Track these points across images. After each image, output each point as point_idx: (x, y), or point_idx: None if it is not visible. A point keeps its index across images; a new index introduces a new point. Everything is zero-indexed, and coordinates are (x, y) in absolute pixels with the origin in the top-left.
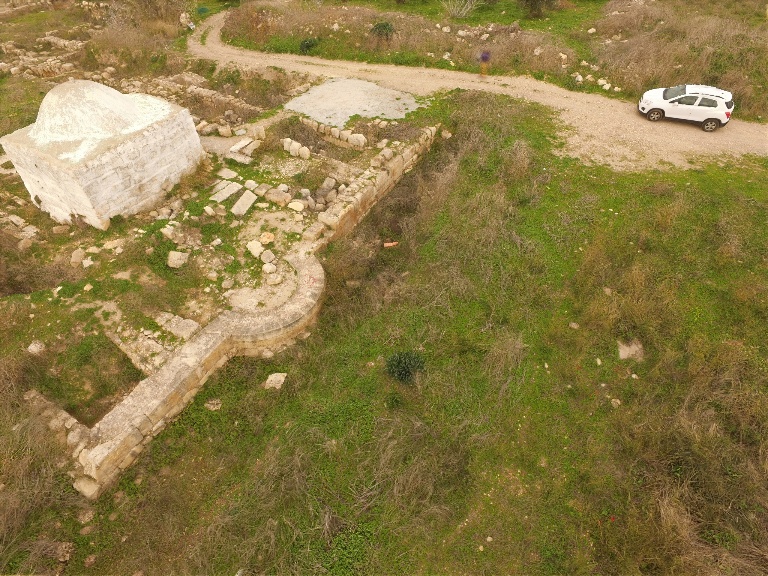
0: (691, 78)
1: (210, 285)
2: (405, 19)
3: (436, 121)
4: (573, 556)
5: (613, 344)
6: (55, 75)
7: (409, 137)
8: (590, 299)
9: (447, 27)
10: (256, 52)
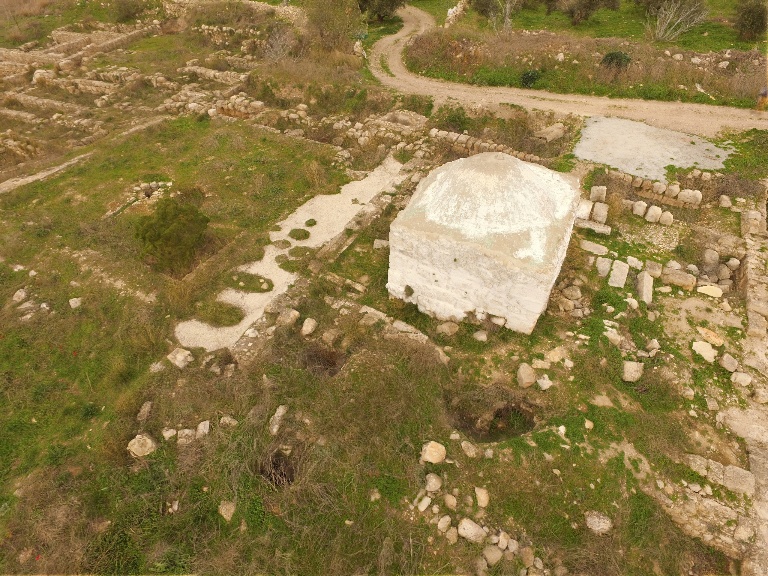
0: None
1: (692, 406)
2: (630, 46)
3: (766, 171)
4: None
5: None
6: (236, 113)
7: (753, 193)
8: None
9: (679, 54)
10: (463, 85)
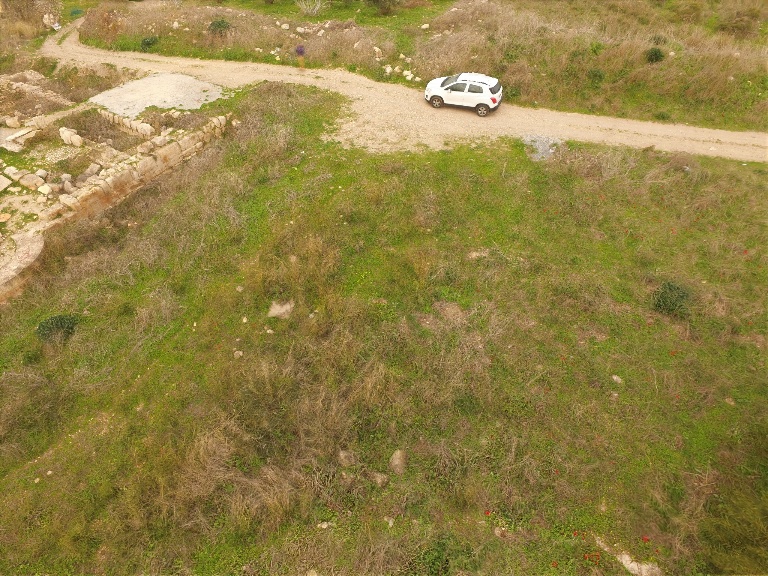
0: (481, 67)
1: None
2: (246, 17)
3: (227, 111)
4: (117, 484)
5: (265, 304)
6: None
7: (193, 126)
8: (268, 265)
9: (286, 24)
10: (104, 50)
